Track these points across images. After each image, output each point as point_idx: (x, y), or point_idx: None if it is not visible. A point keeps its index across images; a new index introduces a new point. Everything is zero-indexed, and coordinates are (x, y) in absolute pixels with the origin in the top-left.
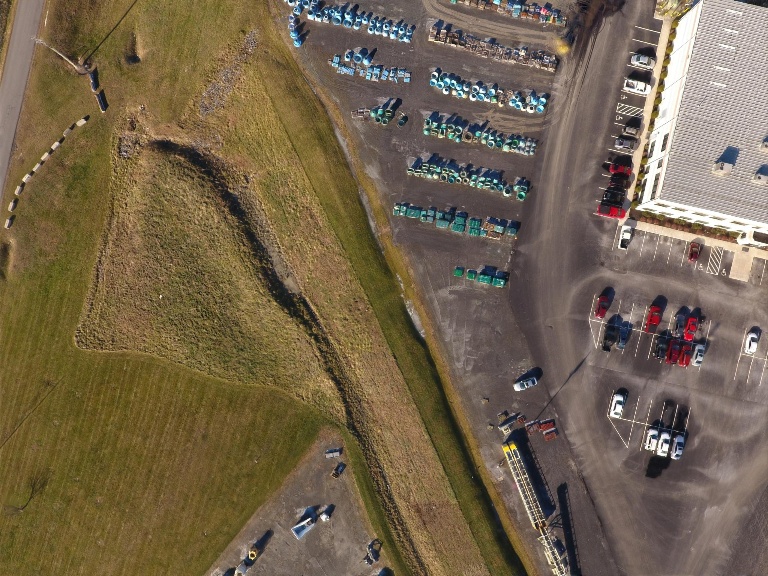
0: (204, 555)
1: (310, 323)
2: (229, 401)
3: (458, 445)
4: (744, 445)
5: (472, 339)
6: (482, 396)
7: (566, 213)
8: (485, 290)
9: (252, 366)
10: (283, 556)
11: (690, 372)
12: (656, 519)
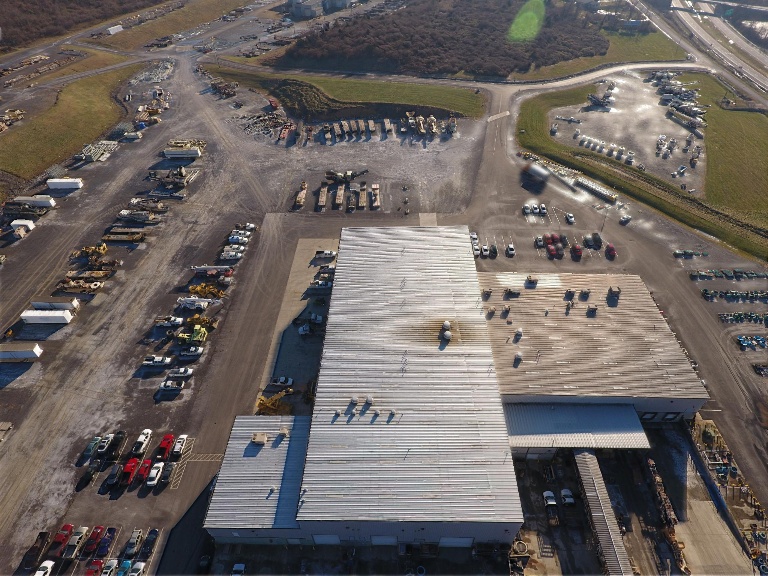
0: (713, 160)
1: (758, 230)
2: (760, 204)
3: (639, 196)
4: (490, 215)
5: (670, 231)
6: (643, 213)
7: (668, 289)
8: (682, 249)
9: (764, 216)
10: (680, 163)
11: (538, 235)
12: (520, 188)
